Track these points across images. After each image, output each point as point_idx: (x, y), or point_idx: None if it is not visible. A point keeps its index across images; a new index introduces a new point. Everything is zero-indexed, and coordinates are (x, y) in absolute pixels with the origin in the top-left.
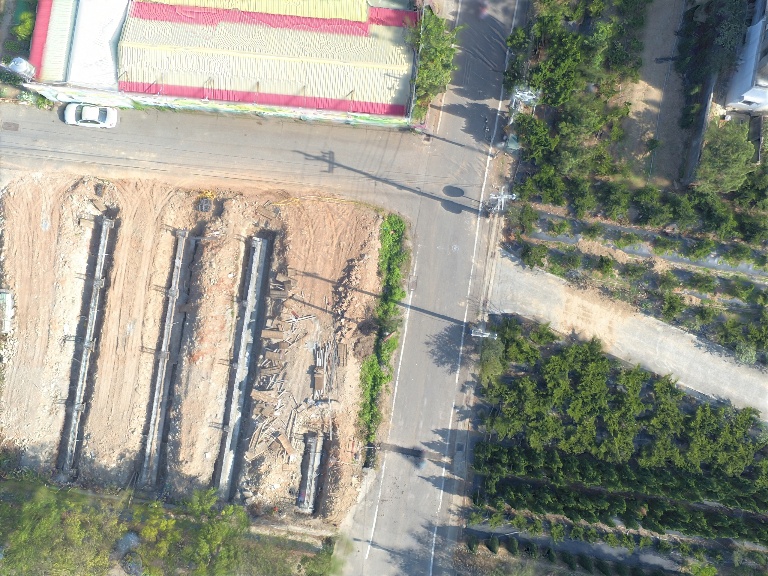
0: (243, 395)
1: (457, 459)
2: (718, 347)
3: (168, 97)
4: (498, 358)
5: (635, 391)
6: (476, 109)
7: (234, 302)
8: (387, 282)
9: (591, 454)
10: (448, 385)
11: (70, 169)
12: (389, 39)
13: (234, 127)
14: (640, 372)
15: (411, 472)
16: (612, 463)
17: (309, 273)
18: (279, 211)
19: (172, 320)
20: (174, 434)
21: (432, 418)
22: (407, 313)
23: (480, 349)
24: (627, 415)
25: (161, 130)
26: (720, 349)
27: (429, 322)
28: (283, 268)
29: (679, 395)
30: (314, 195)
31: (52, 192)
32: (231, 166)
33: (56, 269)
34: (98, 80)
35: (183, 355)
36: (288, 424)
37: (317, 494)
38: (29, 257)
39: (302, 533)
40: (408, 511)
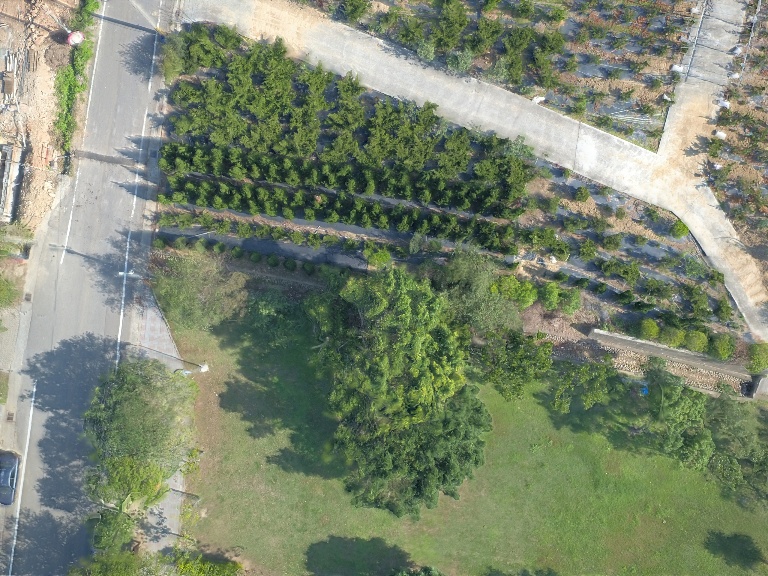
0: None
1: (150, 165)
2: (403, 50)
3: None
4: (178, 55)
5: (317, 89)
6: None
7: None
8: None
9: (275, 152)
10: (141, 93)
11: None
12: None
13: None
14: (324, 73)
15: (104, 178)
16: (292, 157)
17: None
18: None
19: None
20: None
21: (125, 125)
22: (101, 23)
23: None
24: (308, 111)
25: None
26: (406, 52)
27: (122, 31)
28: None
29: (358, 90)
30: None
31: None
32: None
33: None
34: None
35: None
36: None
37: (17, 205)
38: None
39: (0, 241)
40: (102, 216)
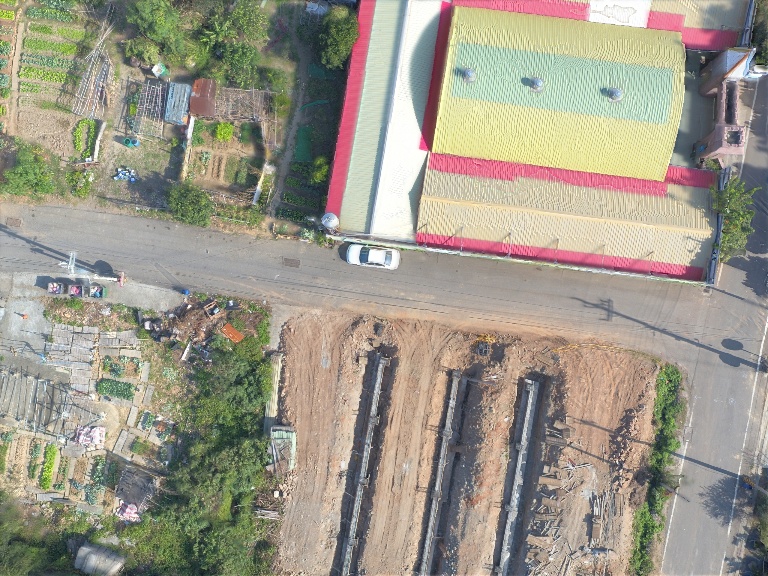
0: (512, 536)
1: None
2: None
3: (465, 250)
4: None
5: None
6: (758, 262)
7: (508, 445)
8: (661, 431)
9: None
10: (720, 537)
11: (350, 307)
12: (690, 200)
13: (514, 272)
14: None
15: None
16: None
17: (587, 421)
18: (559, 359)
19: (445, 459)
20: (448, 574)
21: (703, 568)
22: (681, 463)
23: (753, 502)
24: None
25: (441, 272)
26: None
27: (703, 473)
28: (561, 415)
29: None
30: (592, 343)
31: (332, 330)
32: (510, 311)
33: (336, 407)
34: (398, 231)
35: (460, 498)
36: (561, 569)
37: None
38: (310, 394)
39: None
40: None
